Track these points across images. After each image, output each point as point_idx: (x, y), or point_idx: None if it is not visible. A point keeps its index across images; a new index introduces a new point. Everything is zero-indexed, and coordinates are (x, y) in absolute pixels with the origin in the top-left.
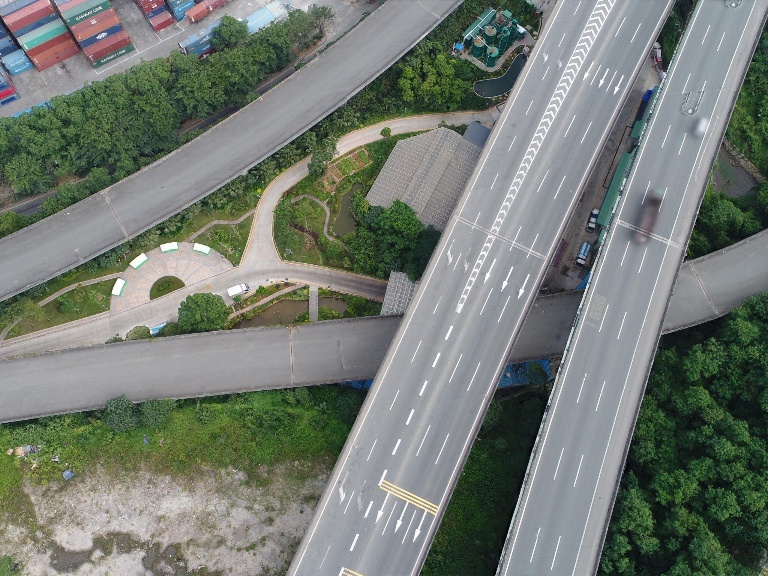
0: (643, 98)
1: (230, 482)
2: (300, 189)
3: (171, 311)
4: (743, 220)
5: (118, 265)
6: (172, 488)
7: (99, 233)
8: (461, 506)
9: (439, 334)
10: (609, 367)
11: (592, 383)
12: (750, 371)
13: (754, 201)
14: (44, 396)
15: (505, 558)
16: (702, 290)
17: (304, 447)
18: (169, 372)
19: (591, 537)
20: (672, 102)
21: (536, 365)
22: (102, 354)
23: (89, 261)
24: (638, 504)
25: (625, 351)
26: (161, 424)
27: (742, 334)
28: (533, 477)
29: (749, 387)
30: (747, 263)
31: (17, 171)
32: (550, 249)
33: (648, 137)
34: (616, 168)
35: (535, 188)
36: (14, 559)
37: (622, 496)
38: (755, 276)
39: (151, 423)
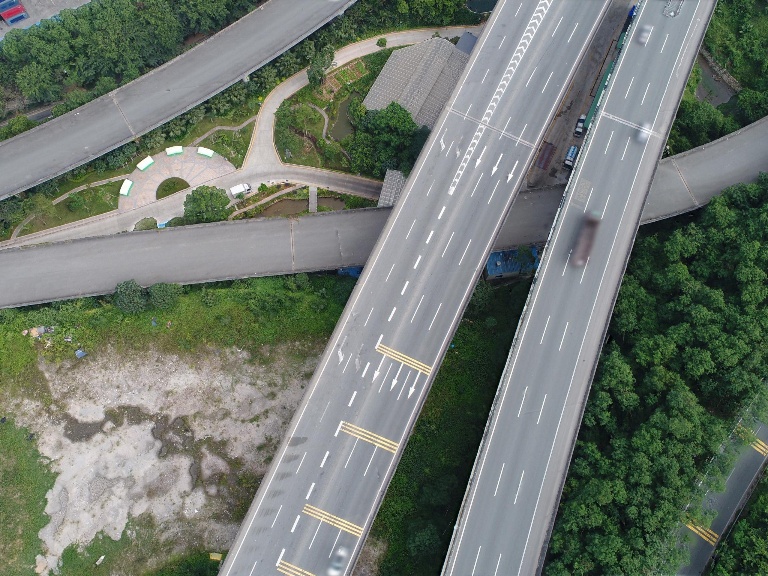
0: (629, 13)
1: (234, 360)
2: (300, 97)
3: (177, 210)
4: (723, 122)
5: (125, 167)
6: (179, 366)
7: (108, 132)
8: (454, 381)
9: (432, 214)
10: (593, 244)
11: (577, 258)
12: (727, 251)
13: (734, 107)
14: (57, 282)
15: (494, 412)
16: (683, 183)
17: (304, 328)
18: (176, 260)
19: (575, 395)
20: (655, 5)
21: (524, 247)
22: (111, 243)
23: (98, 161)
24: (619, 363)
25: (608, 230)
26: (168, 306)
27: (720, 217)
28: (521, 341)
29: (726, 265)
30: (726, 158)
31: (28, 78)
32: (538, 138)
33: (632, 37)
34: (603, 76)
35: (524, 83)
36: (30, 430)
37: (605, 359)
38: (734, 170)
39: (159, 304)
